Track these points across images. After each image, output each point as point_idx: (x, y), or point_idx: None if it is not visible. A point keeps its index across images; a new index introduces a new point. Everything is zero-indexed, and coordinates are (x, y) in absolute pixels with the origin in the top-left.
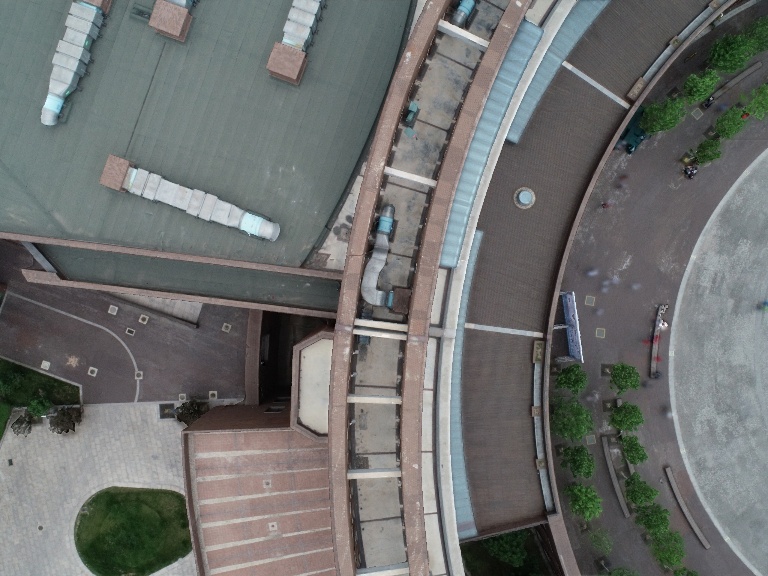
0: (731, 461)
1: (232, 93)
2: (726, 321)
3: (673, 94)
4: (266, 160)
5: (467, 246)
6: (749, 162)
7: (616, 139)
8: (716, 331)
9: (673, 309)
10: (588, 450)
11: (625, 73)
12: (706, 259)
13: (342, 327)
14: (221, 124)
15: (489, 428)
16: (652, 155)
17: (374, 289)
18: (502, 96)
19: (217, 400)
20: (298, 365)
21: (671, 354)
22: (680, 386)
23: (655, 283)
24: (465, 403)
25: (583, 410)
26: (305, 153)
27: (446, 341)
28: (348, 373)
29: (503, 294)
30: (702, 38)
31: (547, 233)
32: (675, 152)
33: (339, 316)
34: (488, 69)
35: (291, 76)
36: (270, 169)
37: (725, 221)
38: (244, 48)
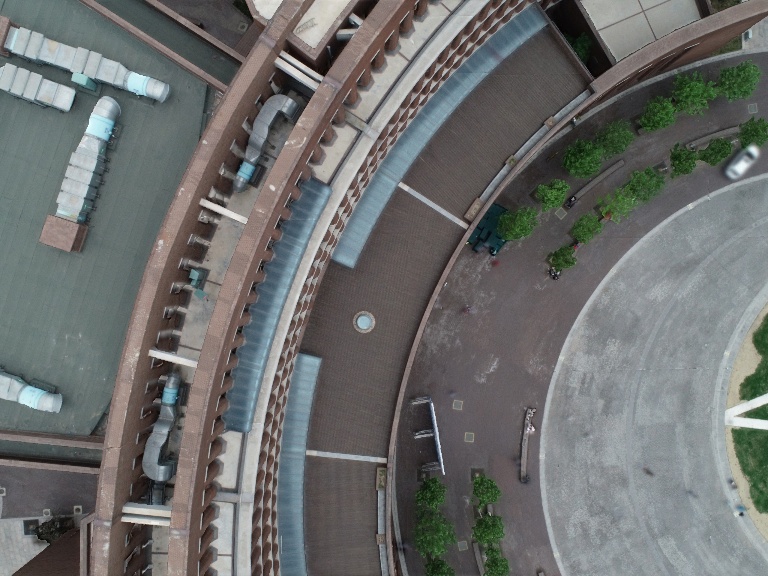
0: (606, 563)
1: (14, 261)
2: (596, 422)
3: (535, 194)
4: (51, 328)
5: (262, 408)
6: (615, 261)
7: (452, 263)
8: (587, 432)
9: (542, 411)
10: (460, 556)
11: (463, 193)
12: (574, 360)
13: (101, 522)
14: (4, 292)
15: (335, 556)
16: (516, 256)
17: (155, 464)
18: (290, 257)
19: (82, 515)
20: (86, 539)
21: (542, 457)
22: (552, 489)
23: (523, 385)
24: (310, 531)
25: (440, 527)
26: (91, 319)
27: (243, 505)
28: (117, 563)
29: (345, 420)
30: (563, 137)
31: (388, 357)
32: (540, 252)
33: (97, 511)
34: (243, 255)
35: (65, 249)
36: (56, 336)
37: (592, 321)
38: (25, 215)
